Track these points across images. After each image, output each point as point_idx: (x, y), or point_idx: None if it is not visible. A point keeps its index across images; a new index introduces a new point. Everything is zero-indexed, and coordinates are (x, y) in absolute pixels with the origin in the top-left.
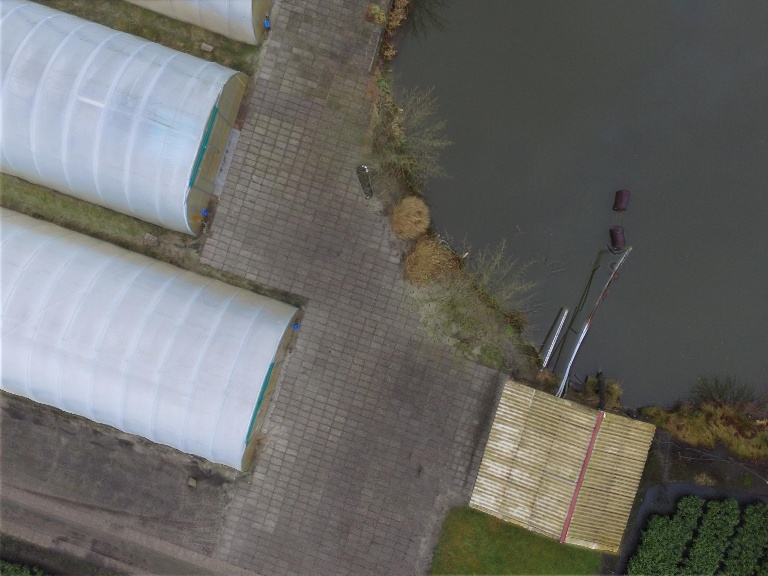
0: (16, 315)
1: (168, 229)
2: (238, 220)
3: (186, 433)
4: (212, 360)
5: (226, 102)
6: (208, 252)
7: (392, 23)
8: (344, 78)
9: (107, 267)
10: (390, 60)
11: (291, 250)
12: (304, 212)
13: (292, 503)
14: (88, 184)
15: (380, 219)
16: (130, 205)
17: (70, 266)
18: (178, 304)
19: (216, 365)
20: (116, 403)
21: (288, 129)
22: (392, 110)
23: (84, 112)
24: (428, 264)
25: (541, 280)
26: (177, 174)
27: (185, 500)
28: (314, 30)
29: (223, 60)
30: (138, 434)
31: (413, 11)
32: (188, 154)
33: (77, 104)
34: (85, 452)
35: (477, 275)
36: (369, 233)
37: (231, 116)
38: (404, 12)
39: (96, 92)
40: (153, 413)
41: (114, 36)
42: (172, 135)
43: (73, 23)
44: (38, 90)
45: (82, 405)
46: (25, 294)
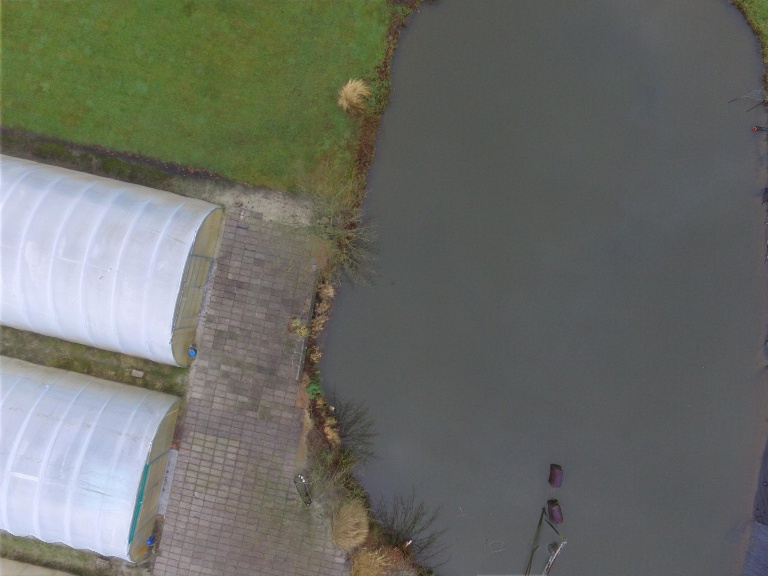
0: None
1: None
2: (185, 536)
3: None
4: None
5: (158, 444)
6: (159, 570)
7: (315, 328)
8: (273, 389)
9: None
10: (317, 363)
11: (239, 560)
12: (248, 523)
13: None
14: None
15: (322, 522)
16: None
17: None
18: None
19: None
20: None
21: (224, 444)
22: (324, 410)
23: (20, 488)
24: (370, 572)
25: (484, 560)
26: (116, 535)
27: None
28: (239, 346)
29: (154, 384)
30: None
31: (334, 312)
32: (124, 518)
33: (12, 481)
34: None
35: (422, 561)
36: (312, 537)
37: (167, 443)
38: (325, 316)
39: (29, 468)
40: None
41: (43, 395)
42: (107, 502)
43: (3, 383)
44: None
45: None
46: None
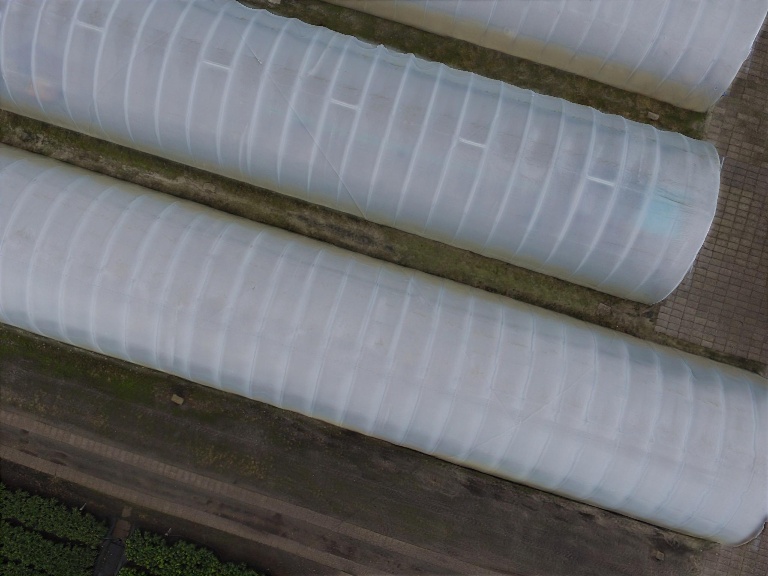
0: (537, 398)
1: (623, 299)
2: (691, 287)
3: (699, 511)
4: (734, 437)
5: None
6: (663, 320)
7: None
8: None
9: (598, 343)
10: None
11: (746, 316)
12: (757, 277)
13: (762, 574)
14: (569, 259)
15: None
16: (607, 278)
17: (569, 344)
18: (680, 379)
19: (739, 442)
20: (631, 483)
21: (737, 194)
22: None
23: (595, 191)
24: None
25: None
26: (685, 249)
27: (654, 574)
28: (758, 95)
29: (670, 128)
30: (621, 510)
31: None
32: (701, 230)
33: (588, 183)
34: (549, 528)
35: None
36: None
37: None
38: None
39: (606, 171)
40: (671, 493)
41: (595, 111)
42: (684, 211)
43: (549, 99)
44: (550, 171)
45: (589, 485)
46: (542, 376)
